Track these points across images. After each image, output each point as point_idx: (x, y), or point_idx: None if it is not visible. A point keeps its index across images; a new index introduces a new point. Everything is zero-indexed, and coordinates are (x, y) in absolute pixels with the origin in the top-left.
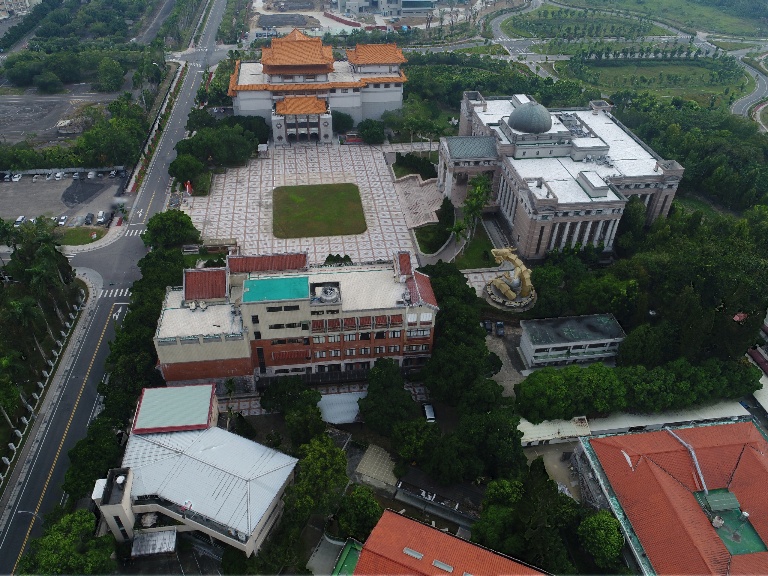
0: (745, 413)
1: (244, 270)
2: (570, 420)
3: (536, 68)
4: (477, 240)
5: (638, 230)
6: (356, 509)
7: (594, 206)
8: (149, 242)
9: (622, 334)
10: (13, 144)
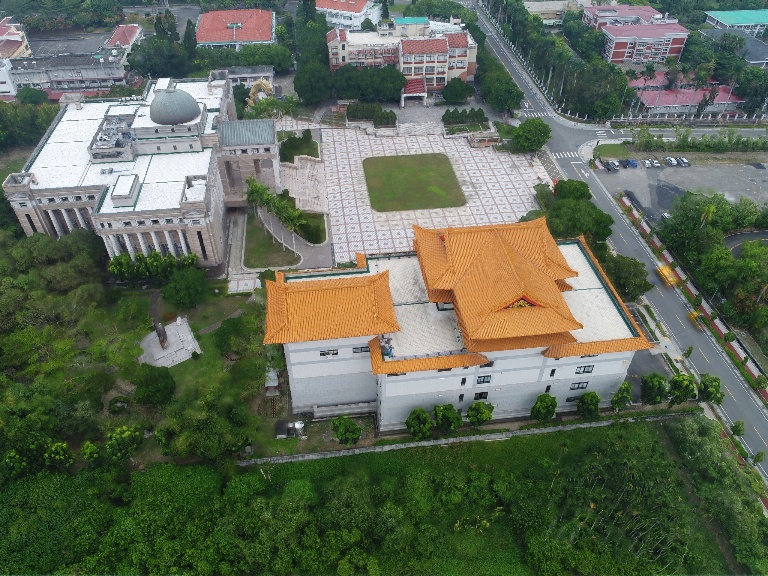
0: None
1: None
2: None
3: None
4: None
5: None
6: None
7: None
8: None
9: None
10: None
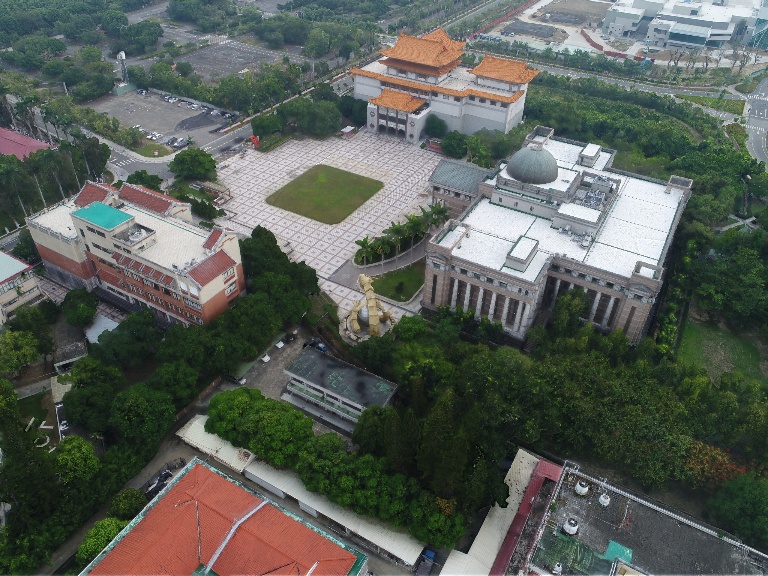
0: (408, 560)
1: (127, 198)
2: (237, 448)
3: (744, 135)
4: (415, 271)
5: (557, 329)
6: None
7: (495, 275)
8: (170, 168)
9: None
10: (203, 78)
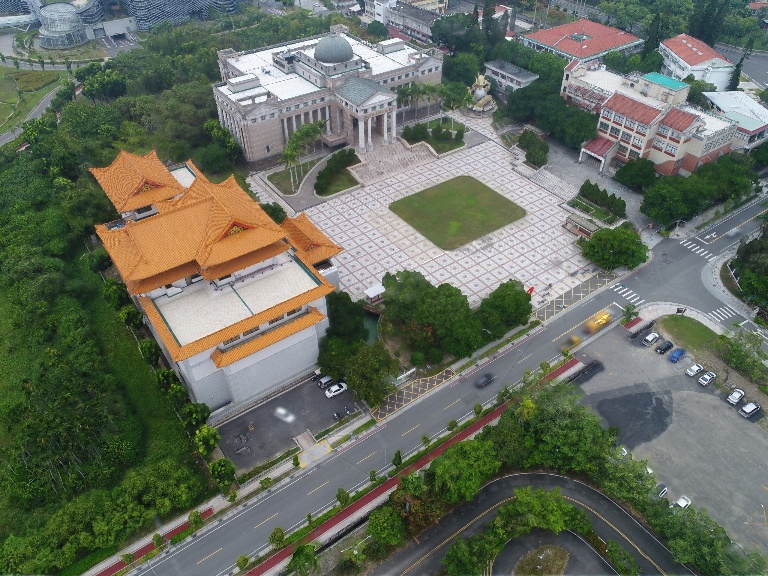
0: None
1: None
2: None
3: None
4: None
5: None
6: (695, 80)
7: None
8: None
9: (497, 61)
10: None
